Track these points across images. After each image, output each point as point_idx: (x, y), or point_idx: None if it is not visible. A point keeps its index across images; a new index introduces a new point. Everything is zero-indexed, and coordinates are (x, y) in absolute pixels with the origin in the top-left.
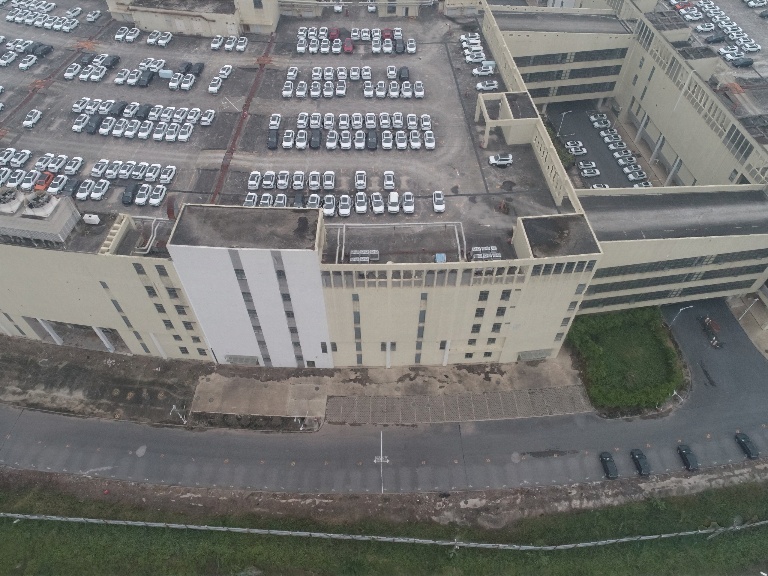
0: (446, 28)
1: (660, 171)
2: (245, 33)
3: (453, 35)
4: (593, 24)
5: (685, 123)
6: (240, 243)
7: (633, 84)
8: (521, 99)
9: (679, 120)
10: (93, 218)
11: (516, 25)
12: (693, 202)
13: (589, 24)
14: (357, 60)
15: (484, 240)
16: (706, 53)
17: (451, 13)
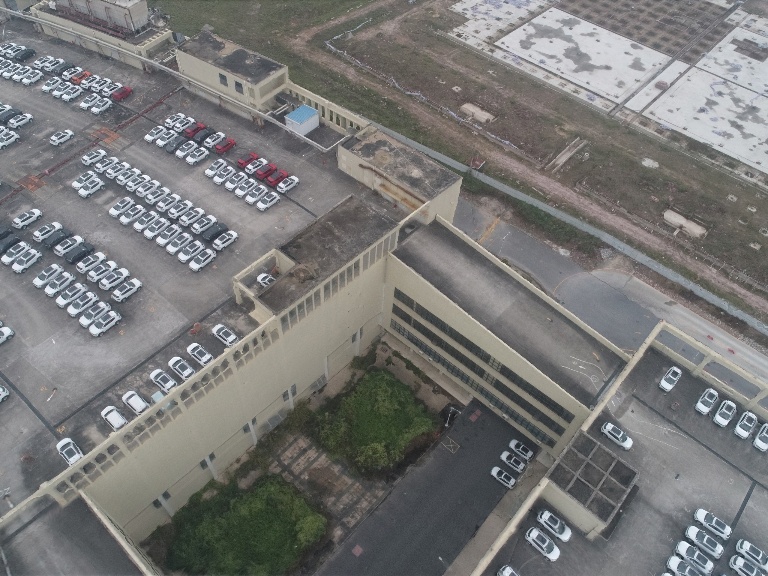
0: None
1: None
2: None
3: None
4: None
5: None
6: None
7: None
8: None
9: None
10: (52, 2)
11: None
12: None
13: None
14: None
15: None
16: None
17: None
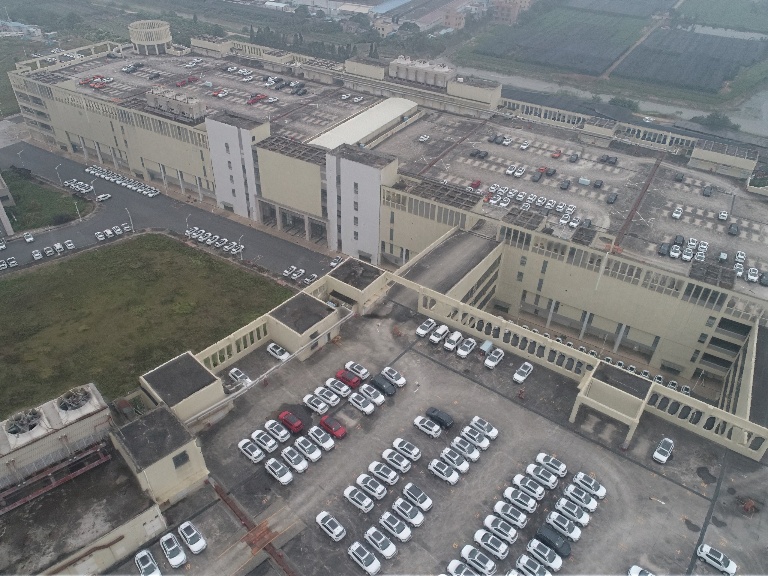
0: (384, 330)
1: (593, 341)
2: (163, 512)
3: (402, 334)
4: (462, 247)
5: (619, 296)
6: None
7: (519, 281)
8: (609, 372)
9: (608, 296)
10: None
11: (427, 286)
12: (767, 369)
13: (460, 249)
14: (364, 438)
15: None
16: (586, 233)
17: (366, 310)
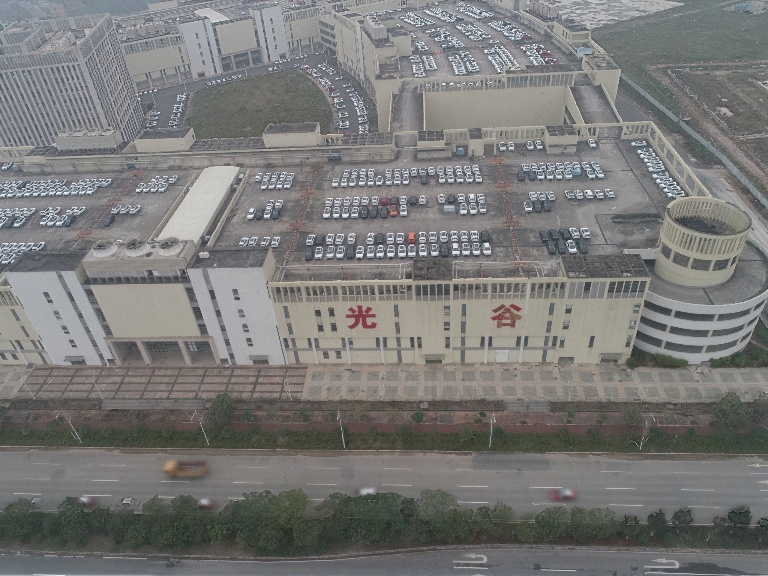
0: None
1: None
2: None
3: None
4: None
5: None
6: None
7: None
8: None
9: None
10: None
11: None
12: None
13: None
14: None
15: None
16: None
17: None
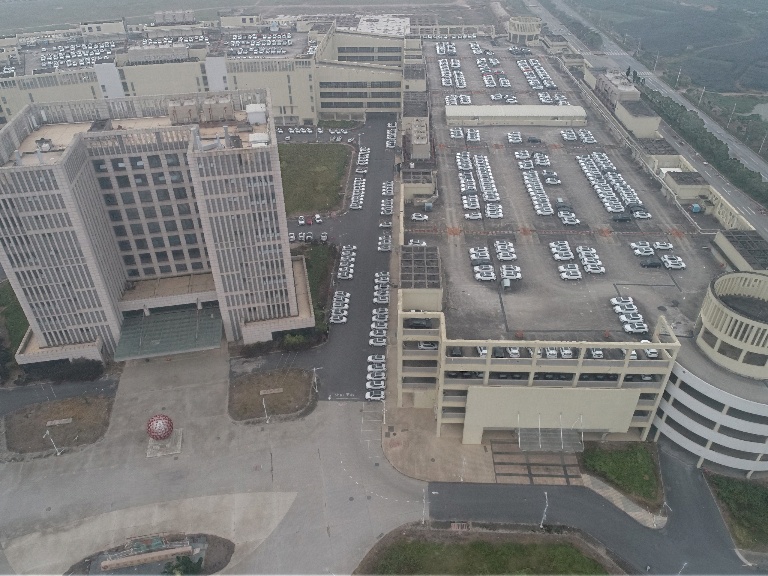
0: None
1: None
2: None
3: None
4: None
5: None
6: (103, 21)
7: None
8: None
9: None
10: None
11: None
12: None
13: None
14: None
15: (30, 48)
16: None
17: None
